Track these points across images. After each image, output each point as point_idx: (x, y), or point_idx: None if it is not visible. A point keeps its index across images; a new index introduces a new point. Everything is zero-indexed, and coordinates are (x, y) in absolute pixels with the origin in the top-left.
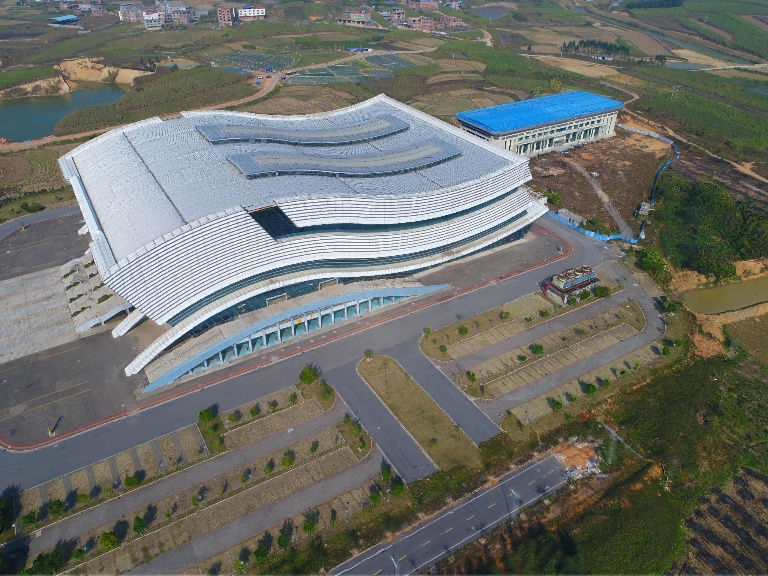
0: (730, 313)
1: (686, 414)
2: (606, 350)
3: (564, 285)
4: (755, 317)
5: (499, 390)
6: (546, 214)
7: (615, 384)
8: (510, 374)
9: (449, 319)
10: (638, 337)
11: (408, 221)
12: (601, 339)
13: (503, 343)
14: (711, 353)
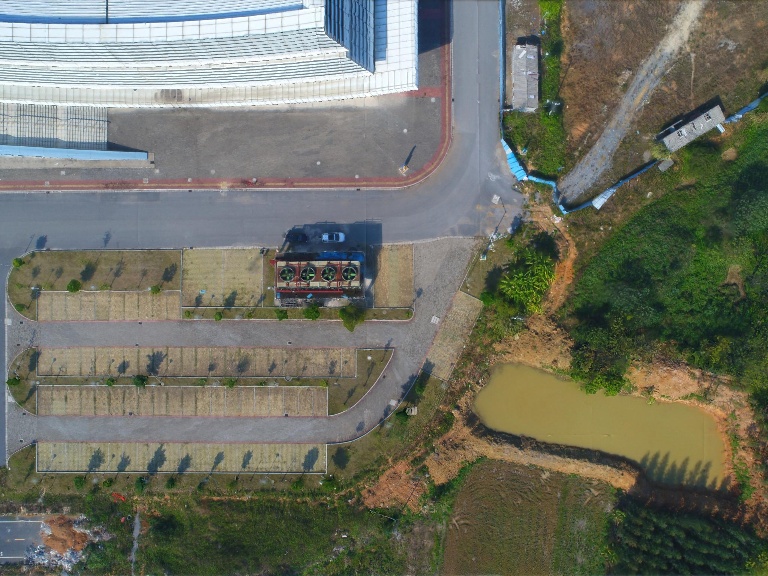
0: (512, 450)
1: (225, 574)
2: (247, 420)
3: (281, 287)
4: (548, 470)
5: (51, 405)
6: (497, 34)
7: (197, 480)
8: (86, 387)
9: (90, 237)
10: (315, 424)
11: (8, 62)
12: (261, 398)
13: (125, 328)
14: (381, 504)
